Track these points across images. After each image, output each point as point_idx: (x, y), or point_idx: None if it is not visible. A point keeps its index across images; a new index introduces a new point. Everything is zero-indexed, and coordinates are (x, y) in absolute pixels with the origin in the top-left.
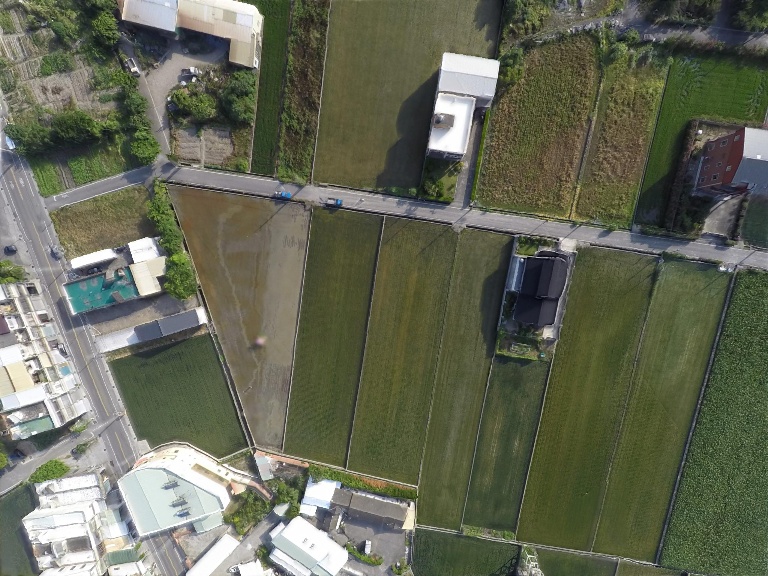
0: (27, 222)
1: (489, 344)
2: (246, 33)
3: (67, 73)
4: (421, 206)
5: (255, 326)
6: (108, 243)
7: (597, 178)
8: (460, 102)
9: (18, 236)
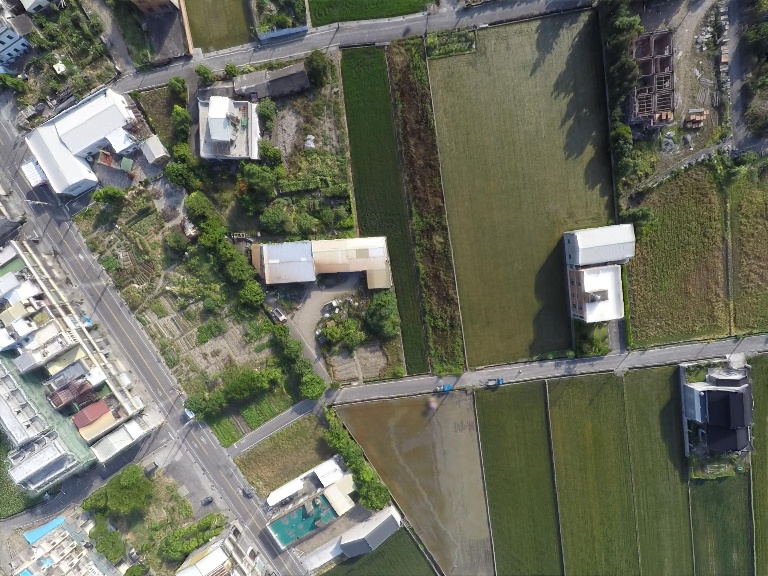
0: (215, 473)
1: (681, 470)
2: (379, 262)
3: (221, 336)
4: (579, 362)
5: (446, 510)
6: (292, 472)
7: (748, 291)
8: (605, 272)
9: (210, 487)
